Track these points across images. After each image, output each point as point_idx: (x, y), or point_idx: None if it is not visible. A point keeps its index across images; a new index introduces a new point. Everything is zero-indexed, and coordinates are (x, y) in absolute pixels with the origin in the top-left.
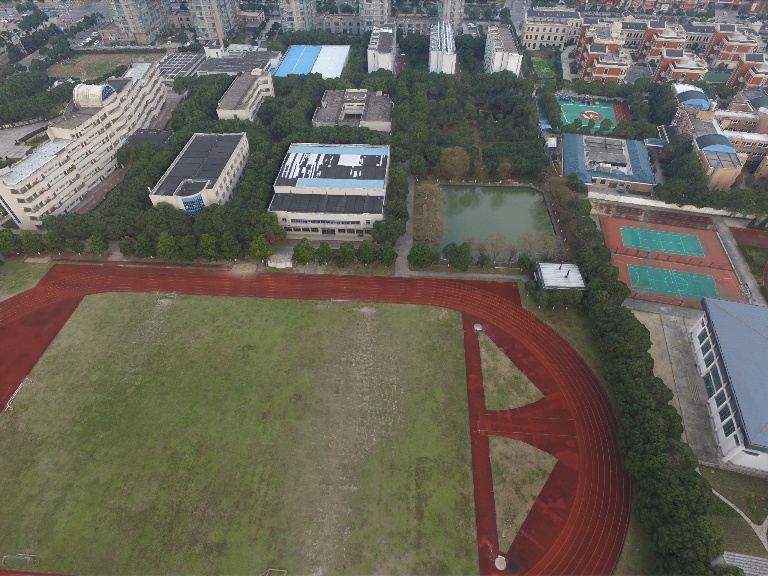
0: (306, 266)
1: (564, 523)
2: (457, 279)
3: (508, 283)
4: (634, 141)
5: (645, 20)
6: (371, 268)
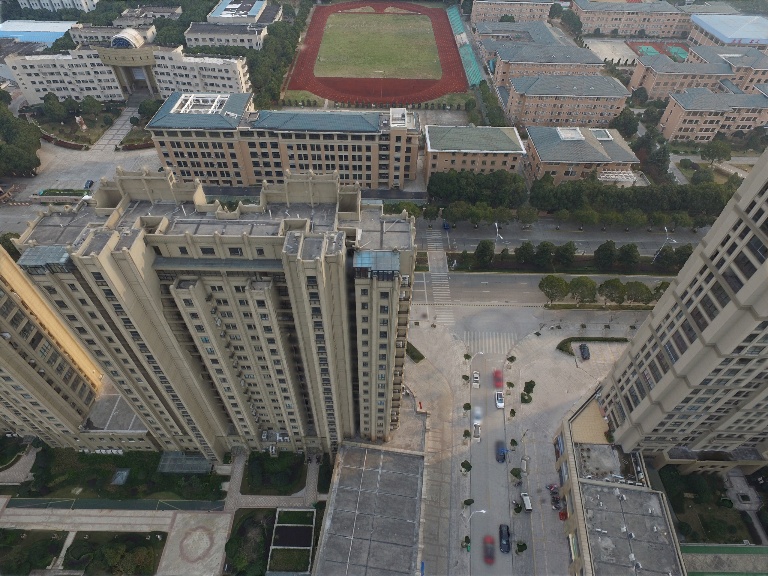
0: None
1: (408, 7)
2: None
3: (317, 6)
4: None
5: None
6: None
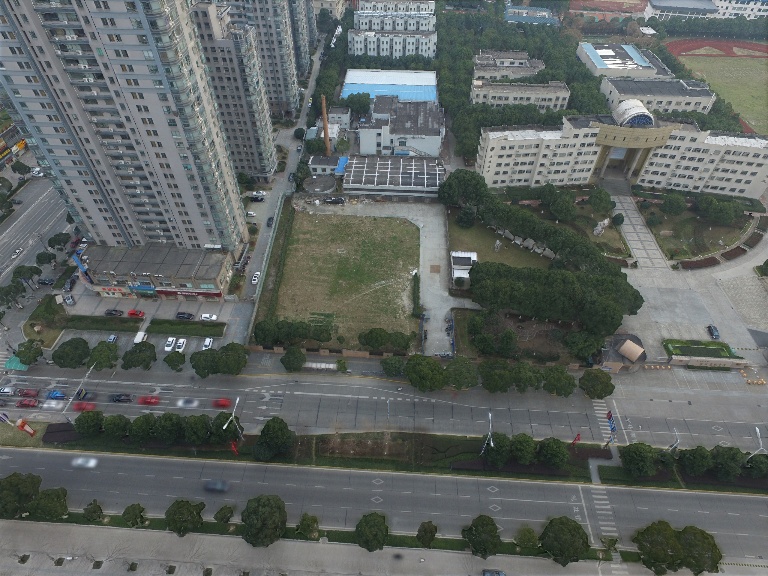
0: None
1: None
2: None
3: None
4: (514, 6)
5: None
6: None
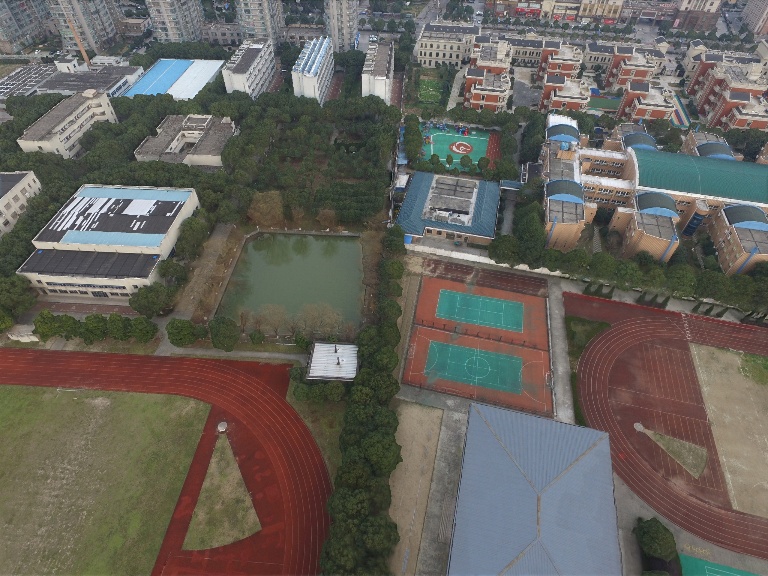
0: (56, 339)
1: None
2: (225, 359)
3: (282, 365)
4: (486, 183)
5: (549, 38)
6: (131, 343)
